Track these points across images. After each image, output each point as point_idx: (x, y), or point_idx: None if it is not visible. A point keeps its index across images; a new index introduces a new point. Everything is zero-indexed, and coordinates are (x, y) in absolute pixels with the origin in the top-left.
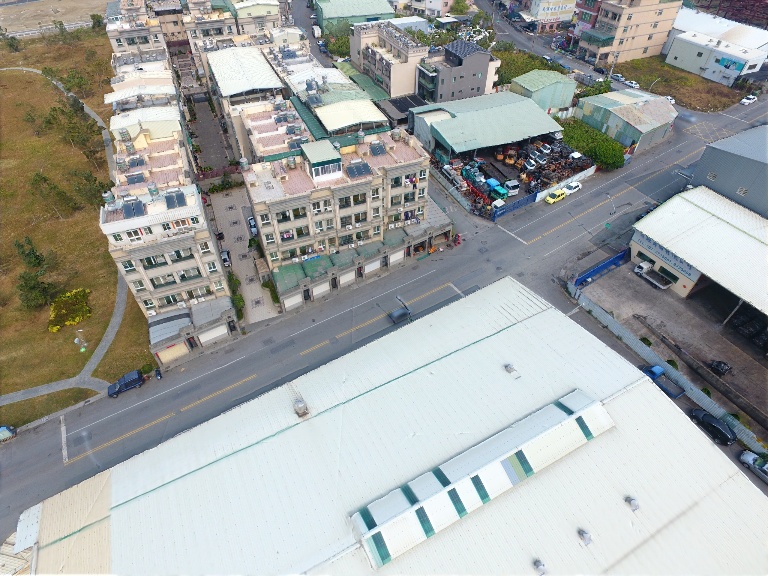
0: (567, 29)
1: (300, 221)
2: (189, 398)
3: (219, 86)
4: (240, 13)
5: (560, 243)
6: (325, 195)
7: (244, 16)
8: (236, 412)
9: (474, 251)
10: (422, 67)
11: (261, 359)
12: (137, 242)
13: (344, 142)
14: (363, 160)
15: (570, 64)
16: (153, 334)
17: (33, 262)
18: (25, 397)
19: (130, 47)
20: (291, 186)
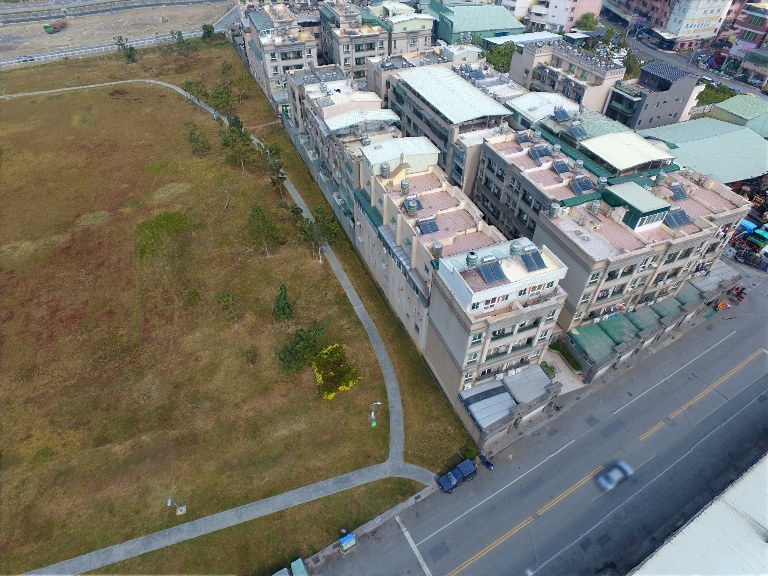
0: (720, 48)
1: (623, 279)
2: (539, 496)
3: (441, 111)
4: (396, 28)
5: None
6: (659, 250)
7: (399, 31)
8: (683, 540)
9: (766, 308)
10: (620, 90)
11: (596, 445)
12: (488, 310)
13: (641, 184)
14: (680, 207)
15: (732, 86)
16: (479, 414)
17: (286, 313)
18: (339, 488)
19: (283, 62)
20: (609, 237)
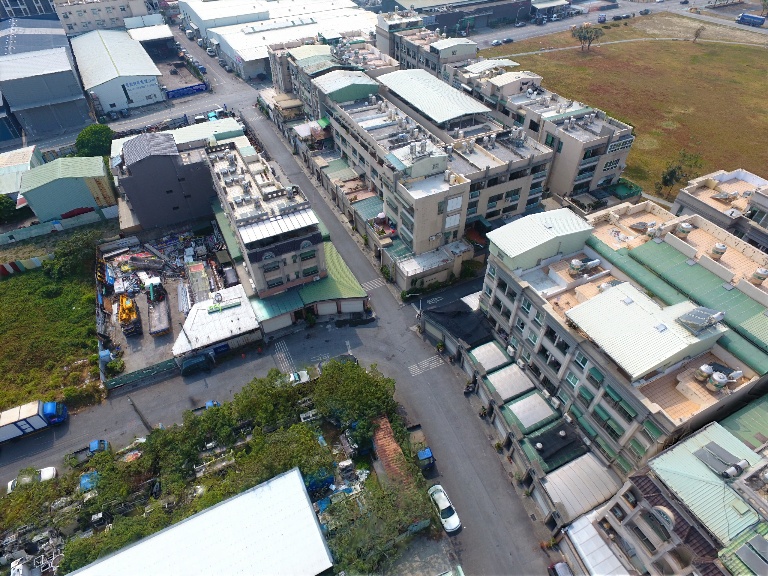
0: None
1: None
2: None
3: None
4: None
5: (195, 105)
6: None
7: None
8: None
9: (250, 101)
10: None
11: None
12: None
13: None
14: None
15: None
16: None
17: None
18: None
19: None
20: None
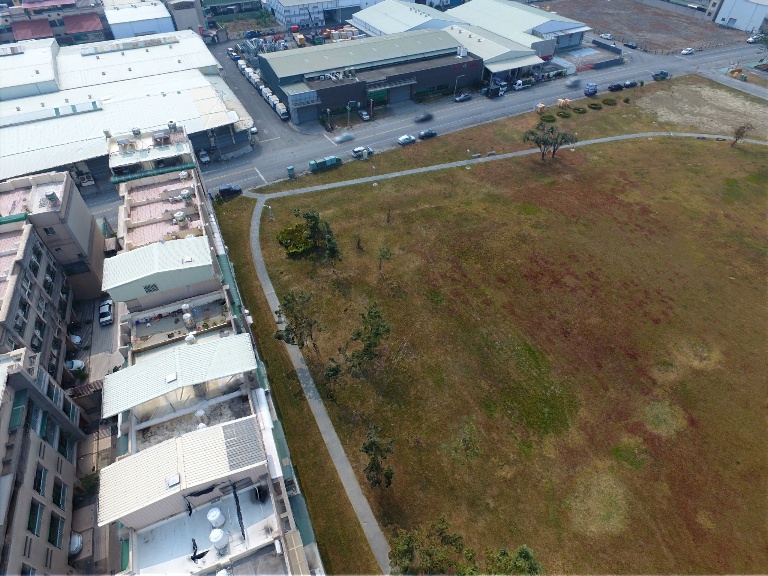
0: None
1: None
2: None
3: None
4: None
5: None
6: None
7: None
8: None
9: None
10: None
11: None
12: None
13: None
14: None
15: None
16: None
17: None
18: (295, 191)
19: None
20: None
